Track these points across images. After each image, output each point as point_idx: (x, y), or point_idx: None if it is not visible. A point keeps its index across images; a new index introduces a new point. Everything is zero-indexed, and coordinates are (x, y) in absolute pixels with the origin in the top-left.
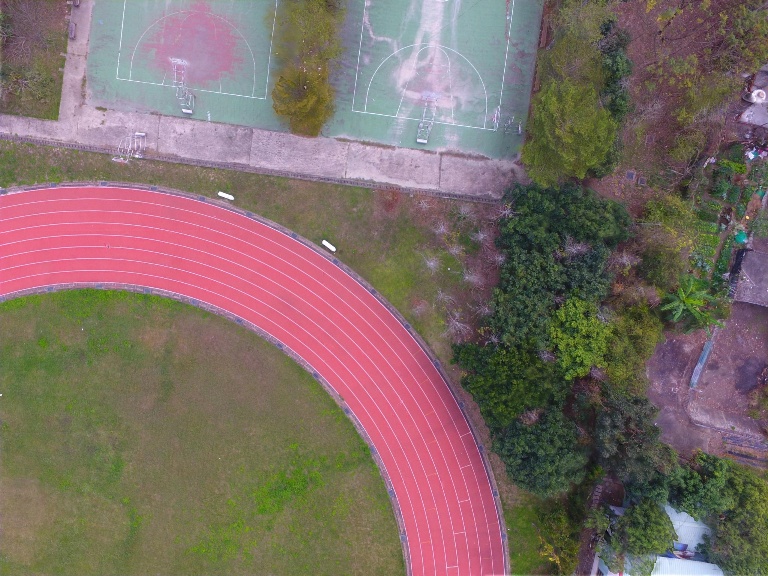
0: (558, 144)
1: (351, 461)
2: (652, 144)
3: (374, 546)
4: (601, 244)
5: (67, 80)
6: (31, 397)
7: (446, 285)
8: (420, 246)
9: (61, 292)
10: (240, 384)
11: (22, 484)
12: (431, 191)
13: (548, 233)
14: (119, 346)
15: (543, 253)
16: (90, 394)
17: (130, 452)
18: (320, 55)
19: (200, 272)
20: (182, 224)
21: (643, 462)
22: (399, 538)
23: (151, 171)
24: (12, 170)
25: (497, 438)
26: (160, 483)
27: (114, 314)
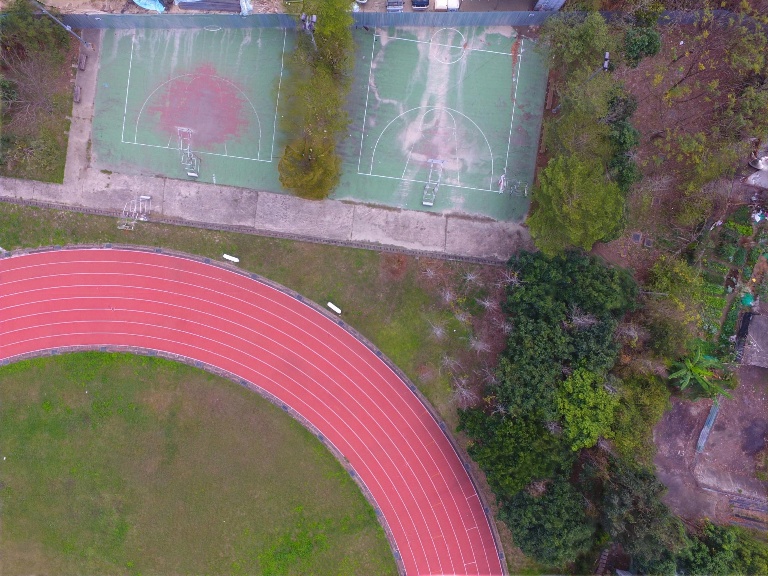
0: (565, 219)
1: (356, 524)
2: (658, 206)
3: None
4: (608, 315)
5: (72, 143)
6: (35, 460)
7: (452, 347)
8: (426, 308)
9: (65, 355)
10: (245, 446)
11: (25, 548)
12: (437, 253)
13: (555, 302)
14: (123, 409)
15: (550, 323)
16: (94, 457)
17: (134, 515)
18: None
19: (205, 334)
20: (187, 286)
21: (651, 540)
22: None
23: (156, 233)
24: (16, 233)
25: (504, 506)
26: (164, 546)
27: (118, 377)
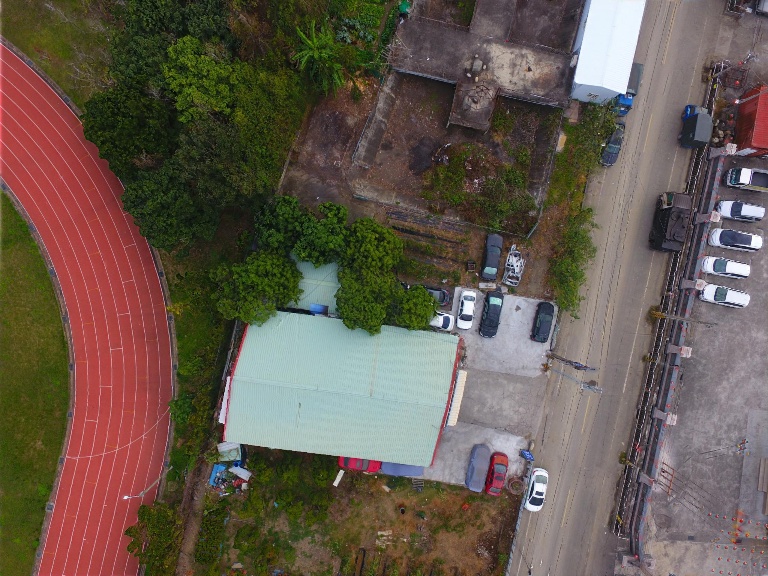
0: None
1: (8, 238)
2: None
3: (34, 327)
4: None
5: None
6: None
7: None
8: (77, 15)
9: None
10: None
11: None
12: None
13: None
14: None
15: None
16: None
17: None
18: None
19: None
20: None
21: (225, 183)
22: (60, 319)
23: None
24: None
25: None
26: None
27: None
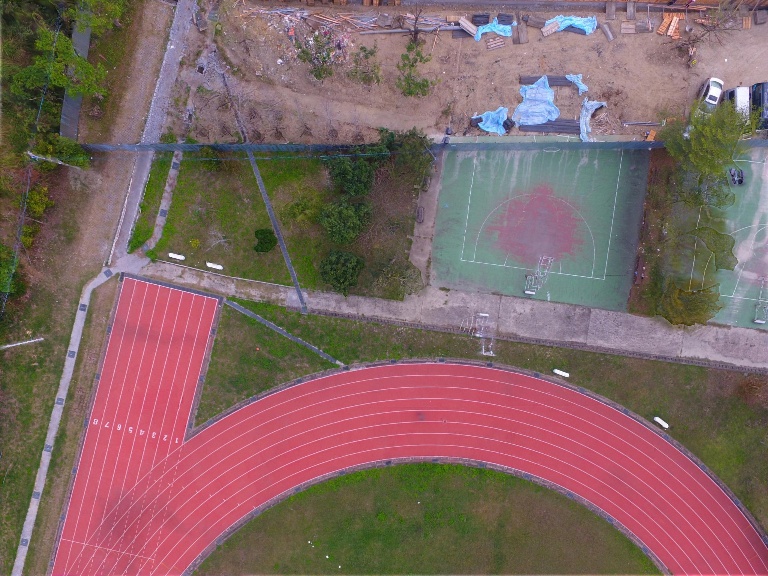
0: None
1: None
2: None
3: None
4: None
5: (412, 261)
6: (368, 569)
7: None
8: (751, 423)
9: (399, 466)
10: (571, 558)
11: None
12: (766, 370)
13: None
14: (454, 520)
15: None
16: (425, 567)
17: None
18: (660, 237)
19: (533, 447)
20: (517, 400)
21: None
22: None
23: None
24: (356, 348)
25: None
26: None
27: (449, 488)
